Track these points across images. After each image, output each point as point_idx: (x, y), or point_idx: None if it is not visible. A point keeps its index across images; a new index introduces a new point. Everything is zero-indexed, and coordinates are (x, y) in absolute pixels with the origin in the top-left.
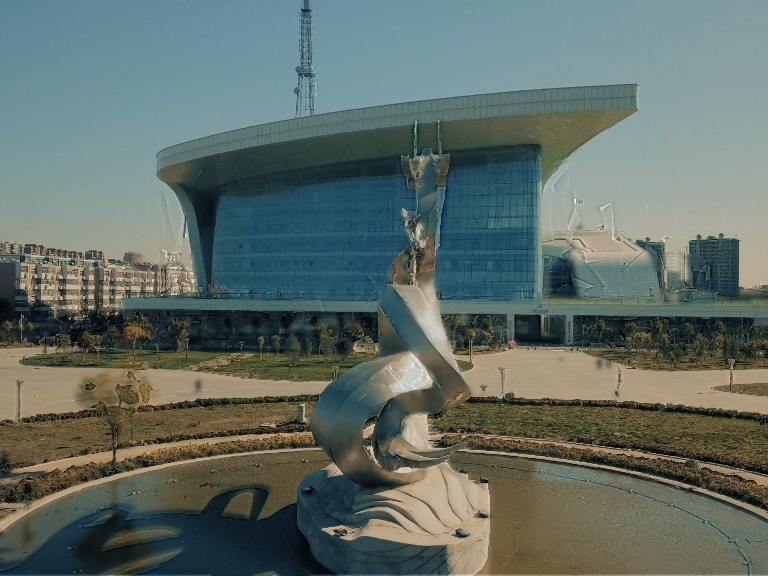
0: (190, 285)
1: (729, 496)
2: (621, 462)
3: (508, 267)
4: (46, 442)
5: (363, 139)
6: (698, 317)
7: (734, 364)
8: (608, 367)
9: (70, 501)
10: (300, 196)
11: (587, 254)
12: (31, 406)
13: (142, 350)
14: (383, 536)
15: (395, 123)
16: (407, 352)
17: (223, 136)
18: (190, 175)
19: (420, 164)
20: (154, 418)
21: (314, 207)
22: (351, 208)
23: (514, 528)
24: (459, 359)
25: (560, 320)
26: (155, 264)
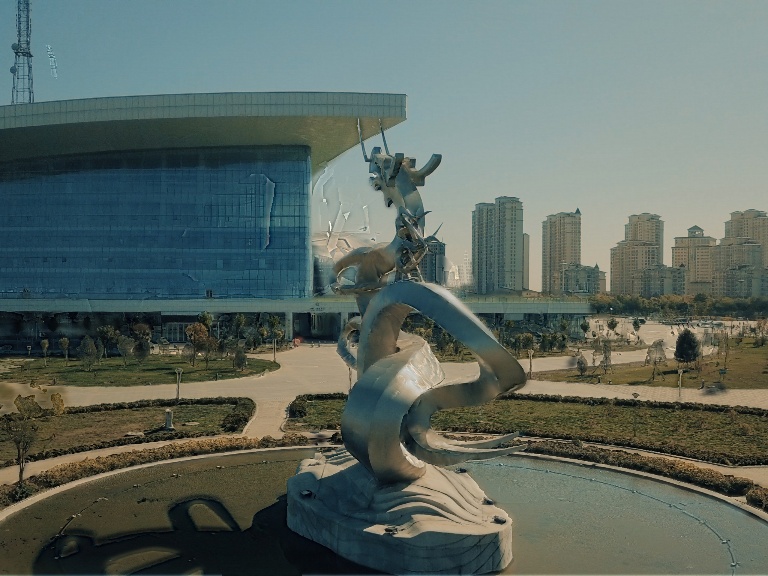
0: None
1: (630, 468)
2: None
3: (280, 266)
4: None
5: (129, 129)
6: None
7: None
8: None
9: (5, 532)
10: (50, 186)
11: None
12: None
13: None
14: (443, 530)
15: (167, 115)
16: (416, 348)
17: None
18: None
19: None
20: None
21: (66, 199)
22: (111, 201)
23: None
24: (258, 358)
25: (329, 318)
26: None
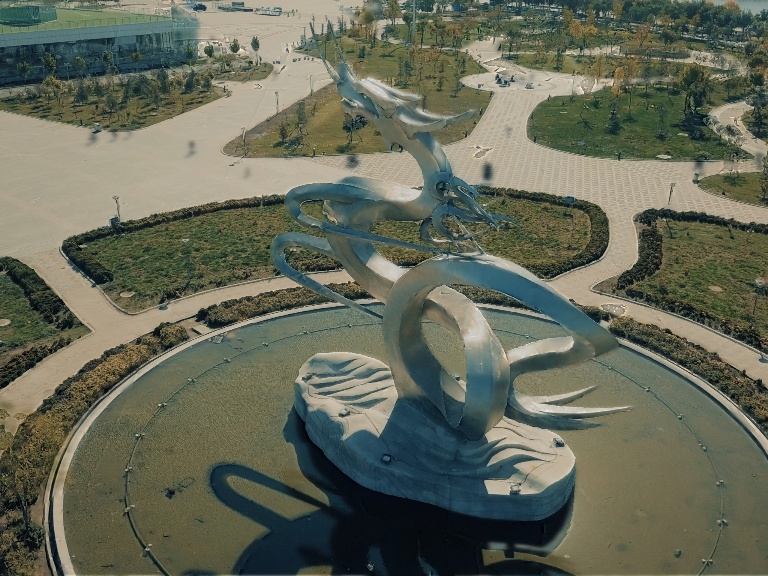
0: None
1: (492, 304)
2: None
3: None
4: None
5: None
6: (65, 42)
7: (164, 105)
8: (74, 134)
9: None
10: None
11: None
12: None
13: None
14: (556, 477)
15: None
16: (476, 313)
17: None
18: None
19: None
20: None
21: None
22: None
23: None
24: None
25: None
26: None
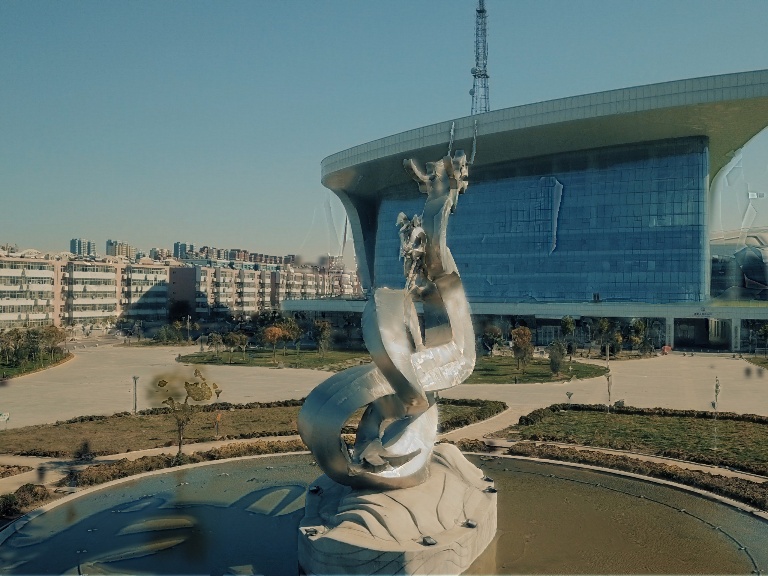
0: (353, 287)
1: None
2: (690, 479)
3: (671, 267)
4: (145, 433)
5: (515, 139)
6: None
7: None
8: (761, 376)
9: (124, 488)
10: None
11: (765, 253)
12: (157, 400)
13: (290, 350)
14: (343, 538)
15: (546, 121)
16: None
17: (379, 142)
18: (350, 181)
19: (440, 167)
20: (255, 415)
21: (470, 209)
22: None
23: (525, 541)
24: (598, 364)
25: None
26: (322, 267)
